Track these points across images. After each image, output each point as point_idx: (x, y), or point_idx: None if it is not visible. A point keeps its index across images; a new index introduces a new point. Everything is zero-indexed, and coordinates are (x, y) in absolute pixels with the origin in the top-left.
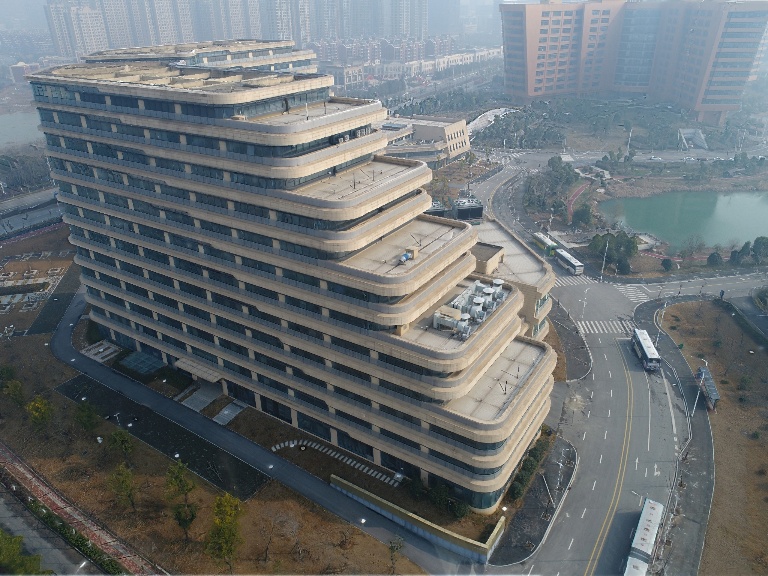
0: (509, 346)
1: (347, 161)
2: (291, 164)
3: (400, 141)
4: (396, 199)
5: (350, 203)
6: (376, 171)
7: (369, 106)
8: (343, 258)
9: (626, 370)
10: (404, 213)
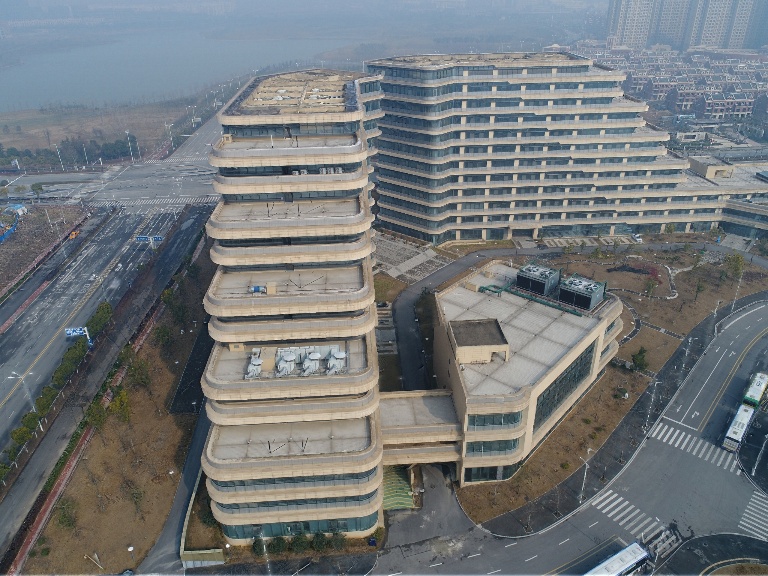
0: (354, 427)
1: (310, 193)
2: (221, 181)
3: (764, 197)
4: (317, 239)
5: (220, 225)
6: (327, 209)
7: (328, 148)
8: (231, 269)
9: (556, 570)
10: (303, 253)
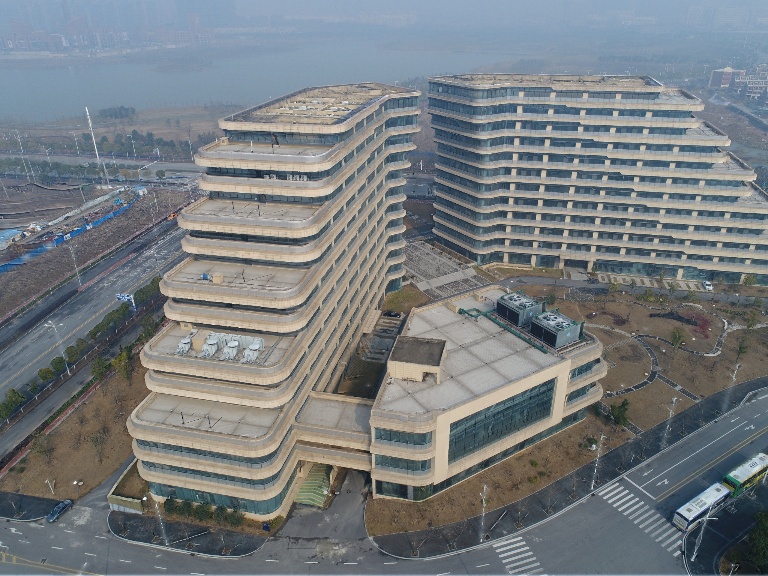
0: (266, 417)
1: None
2: (203, 178)
3: None
4: (271, 239)
5: (185, 216)
6: (289, 213)
7: (292, 156)
8: (199, 257)
9: None
10: (254, 250)
